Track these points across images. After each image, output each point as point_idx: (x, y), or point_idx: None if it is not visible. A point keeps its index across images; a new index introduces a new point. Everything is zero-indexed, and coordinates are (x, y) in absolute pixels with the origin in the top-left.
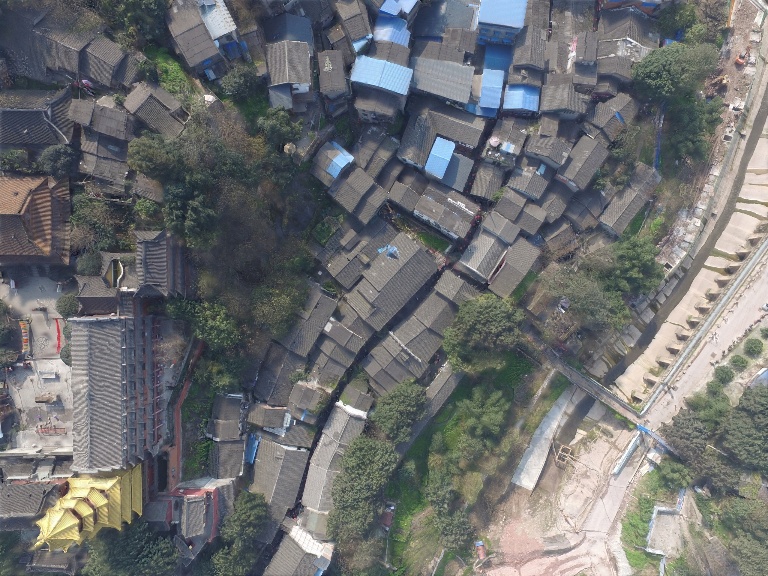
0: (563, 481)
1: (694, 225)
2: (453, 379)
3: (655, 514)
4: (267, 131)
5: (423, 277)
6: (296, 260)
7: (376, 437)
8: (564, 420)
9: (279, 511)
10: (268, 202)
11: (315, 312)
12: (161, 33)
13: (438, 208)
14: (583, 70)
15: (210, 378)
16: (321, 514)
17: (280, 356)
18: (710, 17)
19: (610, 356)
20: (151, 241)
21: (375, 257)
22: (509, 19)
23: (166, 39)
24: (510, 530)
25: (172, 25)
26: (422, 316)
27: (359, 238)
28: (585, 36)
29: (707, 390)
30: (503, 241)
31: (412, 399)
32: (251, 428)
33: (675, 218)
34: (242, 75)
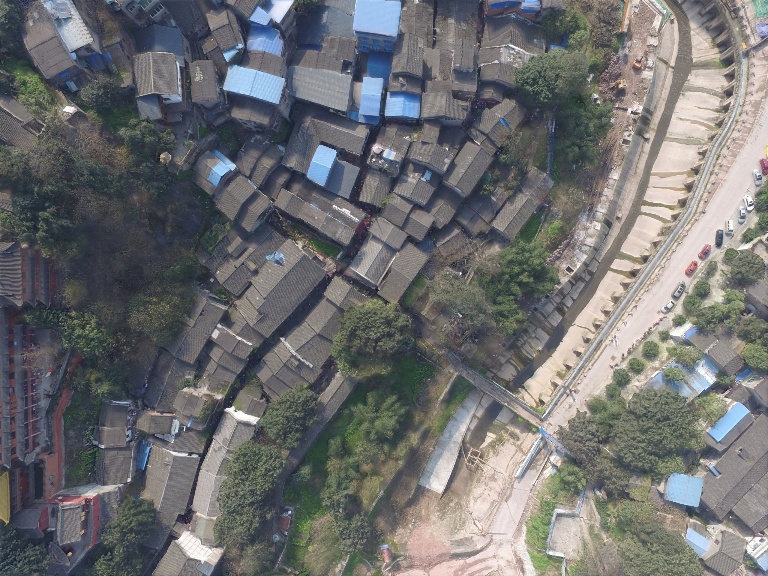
0: (473, 484)
1: (594, 229)
2: (347, 384)
3: (554, 517)
4: (127, 142)
5: (310, 283)
6: (177, 268)
7: (264, 443)
8: (474, 423)
9: (169, 517)
10: (146, 211)
11: (201, 319)
12: (17, 46)
13: (320, 215)
14: (463, 77)
15: (89, 386)
16: (209, 519)
17: (168, 363)
18: (604, 22)
19: (518, 359)
20: (3, 252)
21: (263, 264)
22: (383, 27)
23: (24, 52)
24: (418, 533)
25: (27, 38)
26: (313, 322)
27: (246, 245)
28: (461, 43)
29: (606, 393)
30: (391, 247)
31: (299, 405)
32: (142, 434)
33: (575, 222)
34: (101, 87)
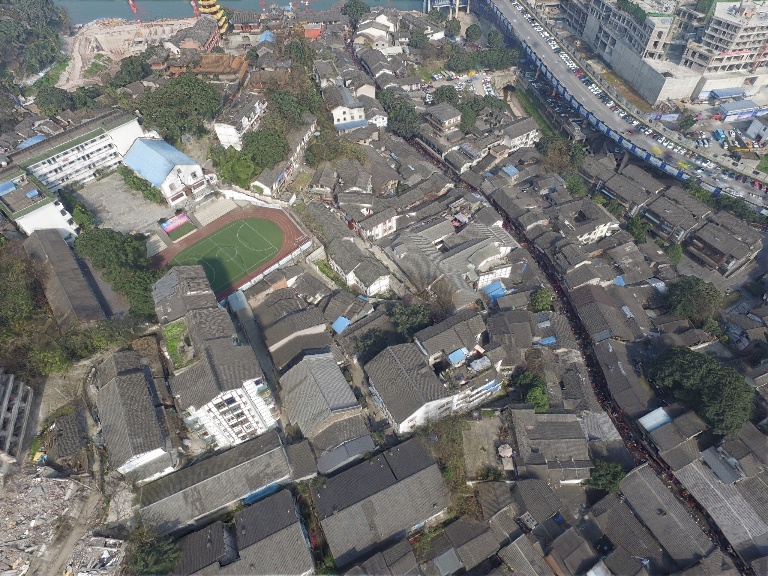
0: None
1: None
2: None
3: (33, 81)
4: None
5: None
6: None
7: None
8: None
9: None
10: None
11: None
12: None
13: (49, 126)
14: None
15: None
16: None
17: None
18: None
19: None
20: None
21: None
22: None
23: None
24: None
25: None
26: None
27: None
28: None
29: None
30: None
31: None
32: None
33: None
34: None
